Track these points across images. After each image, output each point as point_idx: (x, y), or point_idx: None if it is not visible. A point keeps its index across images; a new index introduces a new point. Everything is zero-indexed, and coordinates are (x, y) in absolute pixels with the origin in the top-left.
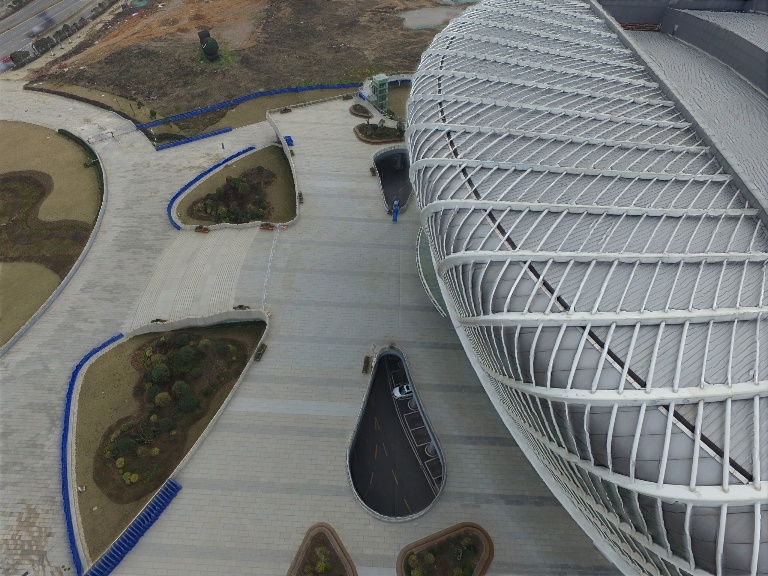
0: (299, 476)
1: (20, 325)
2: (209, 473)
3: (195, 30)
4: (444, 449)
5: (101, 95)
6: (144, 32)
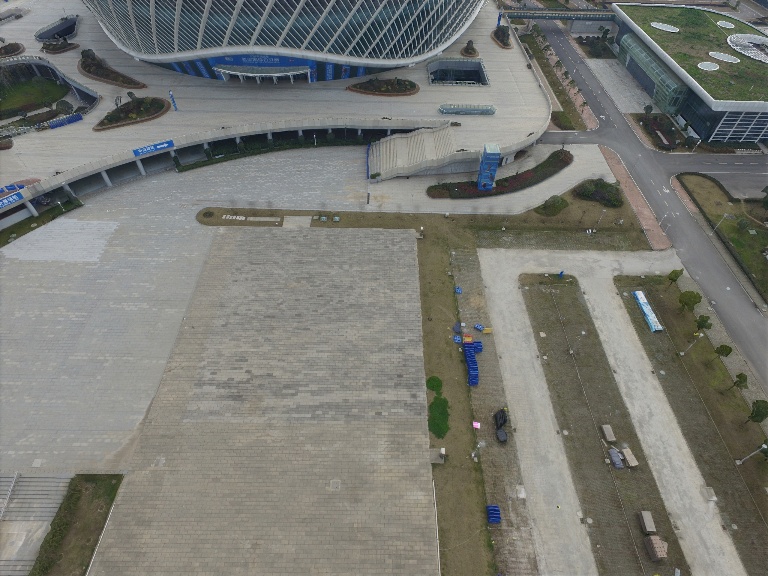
0: (17, 37)
1: None
2: None
3: None
4: (78, 33)
5: None
6: None
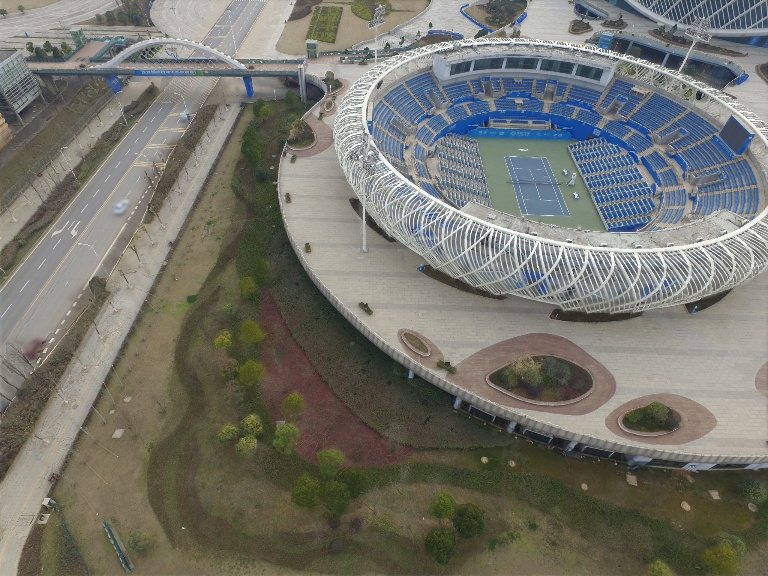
0: None
1: (424, 6)
2: None
3: None
4: None
5: None
6: None
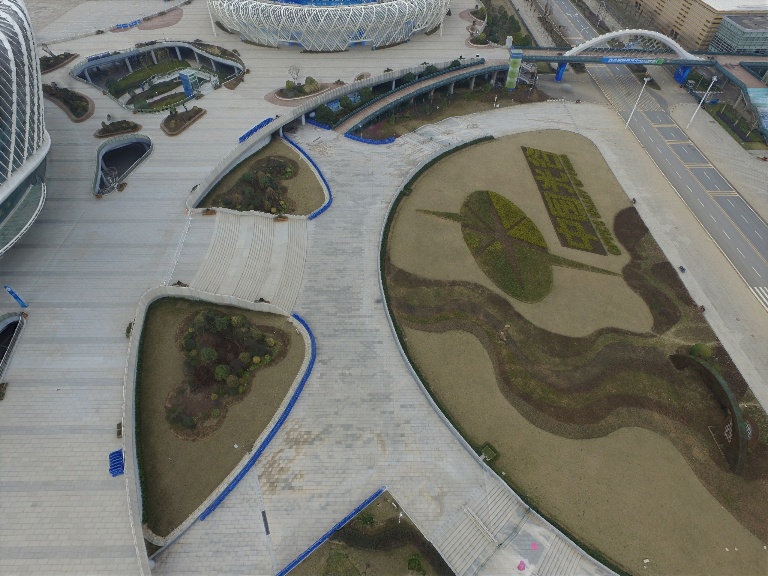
0: None
1: (398, 229)
2: (226, 147)
3: None
4: None
5: None
6: None
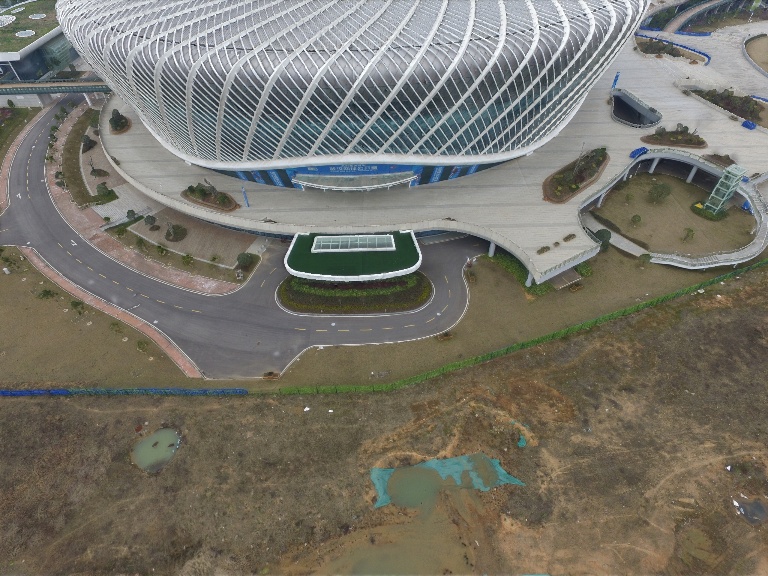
0: None
1: None
2: None
3: None
4: None
5: None
6: None
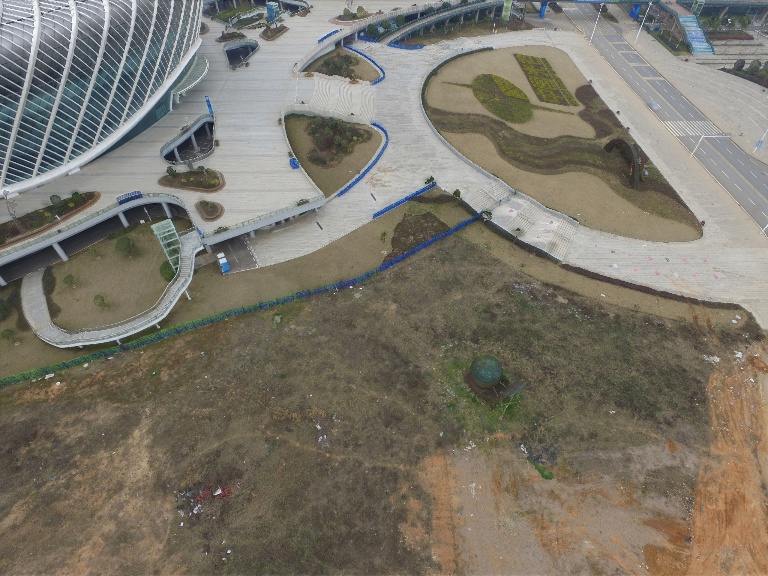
0: None
1: (431, 91)
2: (310, 46)
3: (635, 572)
4: None
5: (606, 295)
6: (759, 537)
